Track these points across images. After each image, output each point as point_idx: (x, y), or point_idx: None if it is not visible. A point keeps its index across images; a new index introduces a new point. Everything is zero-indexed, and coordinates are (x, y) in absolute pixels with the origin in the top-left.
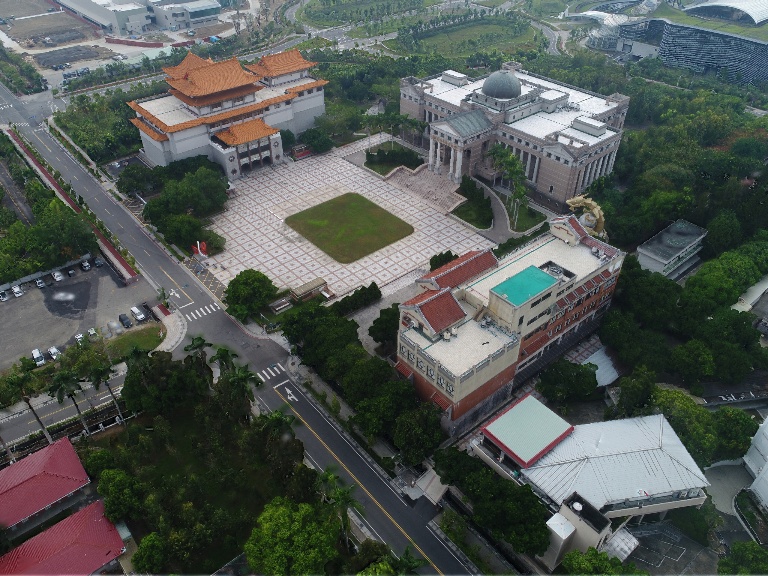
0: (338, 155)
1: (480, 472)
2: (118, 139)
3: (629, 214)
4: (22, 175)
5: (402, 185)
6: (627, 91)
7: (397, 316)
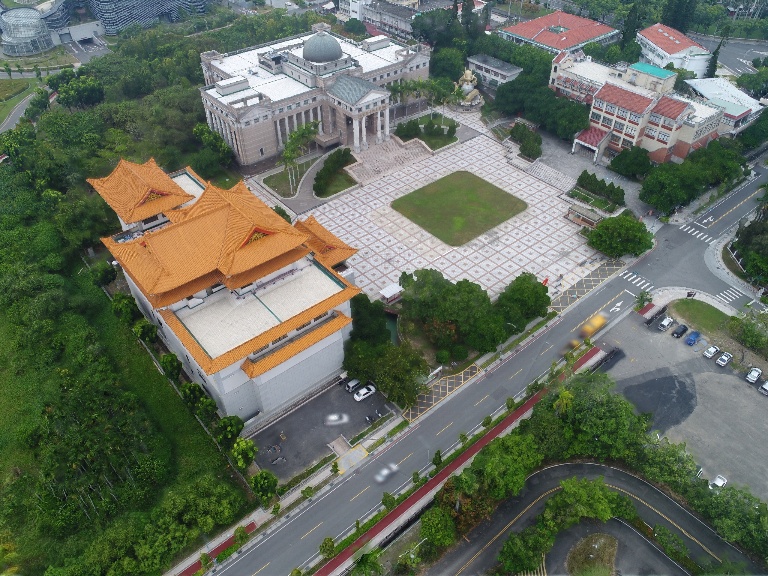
0: (291, 218)
1: (761, 125)
2: (144, 501)
3: (451, 76)
4: (472, 492)
5: (375, 175)
6: (224, 44)
7: (640, 150)
